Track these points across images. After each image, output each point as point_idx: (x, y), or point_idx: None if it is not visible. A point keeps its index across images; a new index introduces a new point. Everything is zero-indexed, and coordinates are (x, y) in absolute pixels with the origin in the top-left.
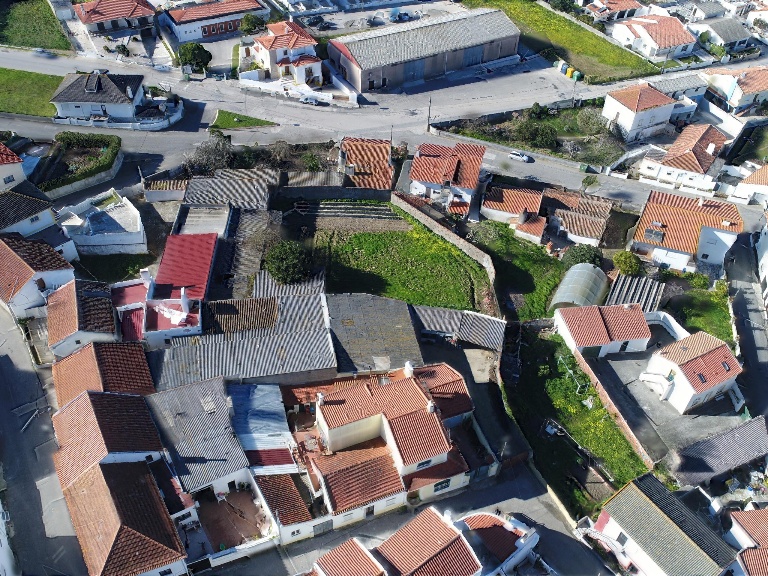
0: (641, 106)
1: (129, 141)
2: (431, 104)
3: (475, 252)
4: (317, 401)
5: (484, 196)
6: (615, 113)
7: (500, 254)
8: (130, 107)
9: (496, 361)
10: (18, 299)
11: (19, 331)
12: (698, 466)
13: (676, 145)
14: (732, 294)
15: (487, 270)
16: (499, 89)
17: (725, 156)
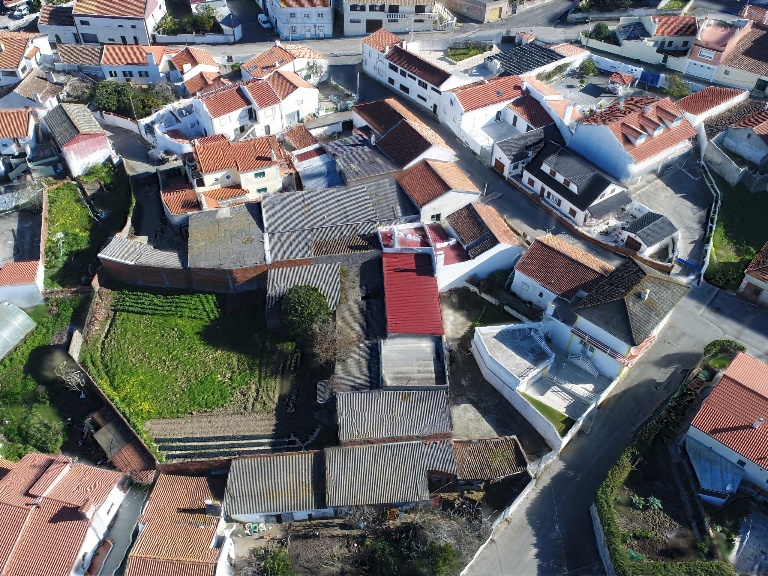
0: None
1: None
2: None
3: None
4: None
5: None
6: None
7: None
8: None
9: None
10: None
11: None
12: None
13: None
14: None
15: None
16: None
17: None
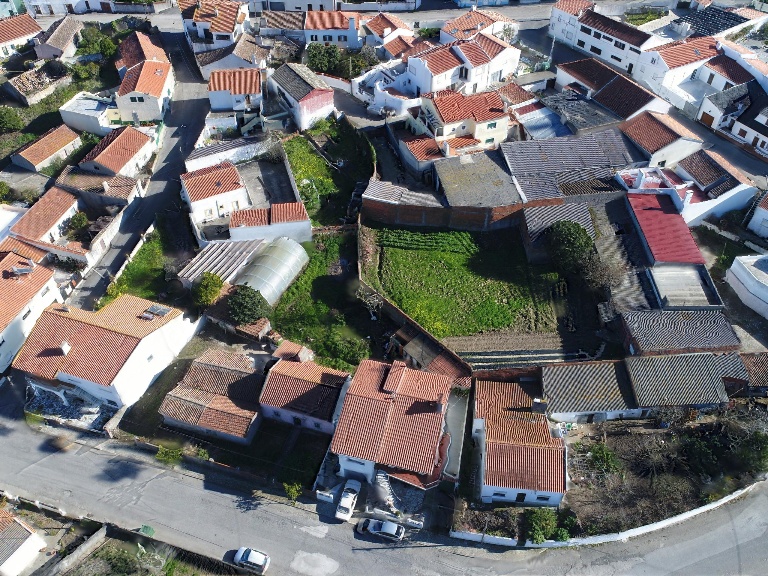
0: None
1: None
2: None
3: None
4: None
5: (348, 379)
6: None
7: None
8: None
9: None
10: None
11: None
12: None
13: None
14: None
15: None
16: None
17: None
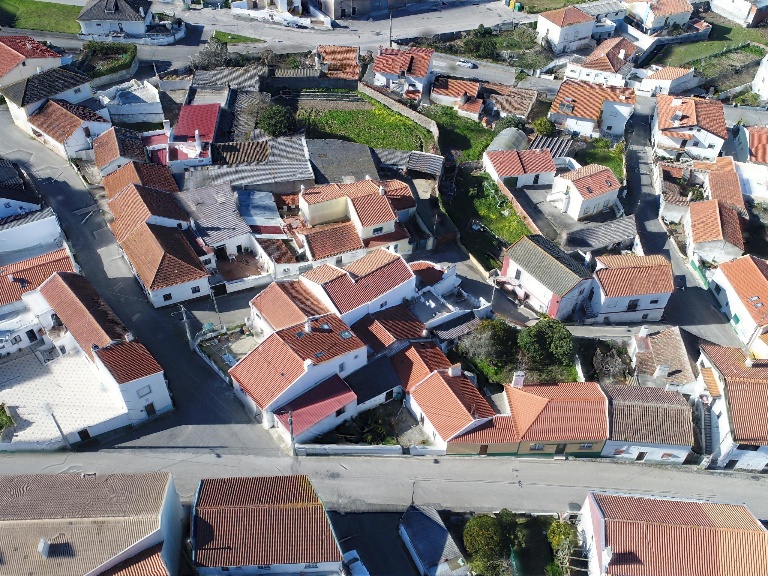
0: (566, 22)
1: (142, 52)
2: (394, 27)
3: (424, 120)
4: (300, 193)
5: (433, 85)
6: (546, 30)
7: (445, 125)
8: (142, 25)
9: (436, 184)
10: (71, 141)
11: (72, 167)
12: (582, 243)
13: (594, 53)
14: (628, 153)
15: (433, 133)
16: (452, 17)
17: (637, 64)
